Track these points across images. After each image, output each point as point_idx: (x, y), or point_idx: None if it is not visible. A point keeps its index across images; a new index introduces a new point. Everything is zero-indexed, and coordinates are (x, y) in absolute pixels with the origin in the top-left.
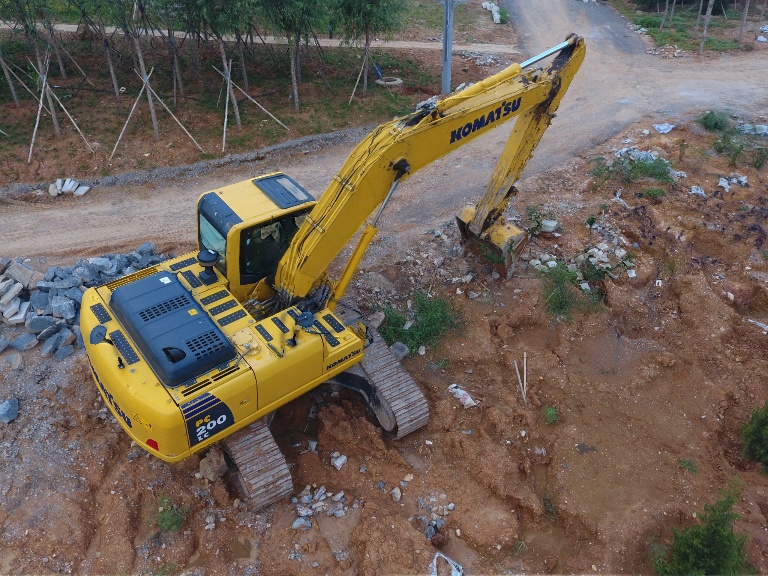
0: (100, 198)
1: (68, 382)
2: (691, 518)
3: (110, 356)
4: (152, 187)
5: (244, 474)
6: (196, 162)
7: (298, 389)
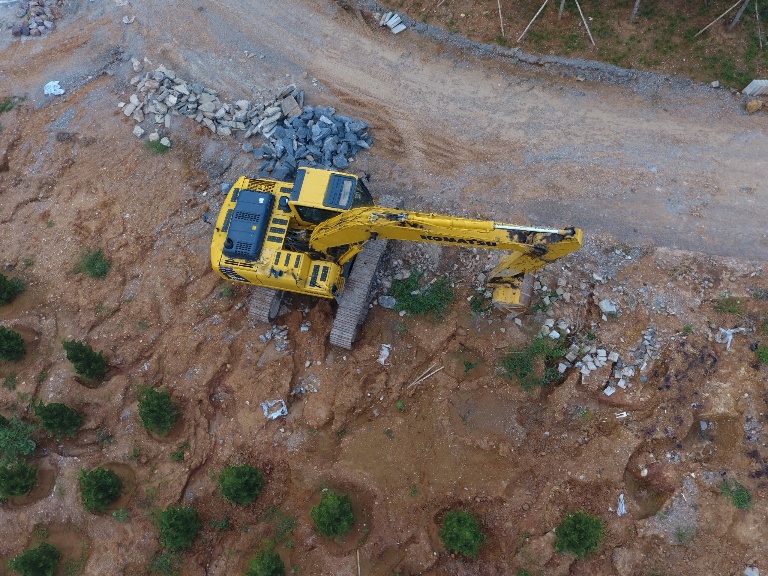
0: (401, 44)
1: None
2: (375, 502)
3: (220, 221)
4: (439, 51)
5: (250, 302)
6: (488, 42)
7: (289, 289)
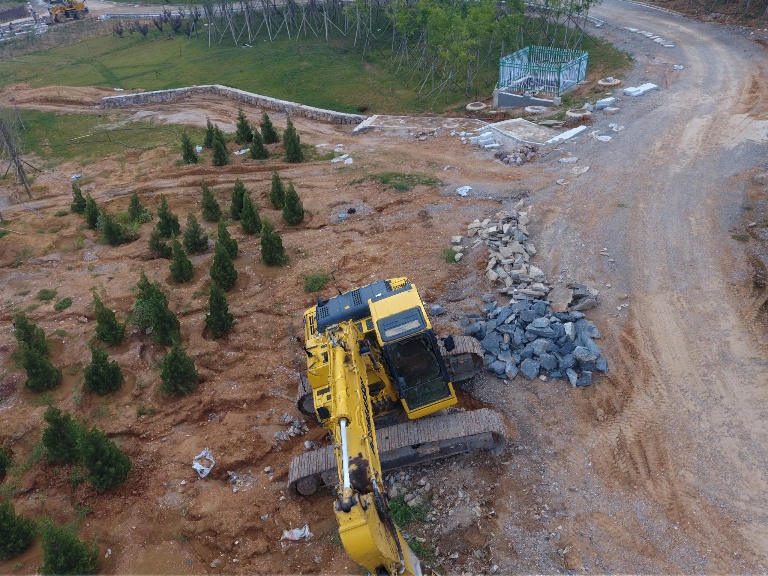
0: None
1: (437, 324)
2: None
3: None
4: None
5: None
6: None
7: None
